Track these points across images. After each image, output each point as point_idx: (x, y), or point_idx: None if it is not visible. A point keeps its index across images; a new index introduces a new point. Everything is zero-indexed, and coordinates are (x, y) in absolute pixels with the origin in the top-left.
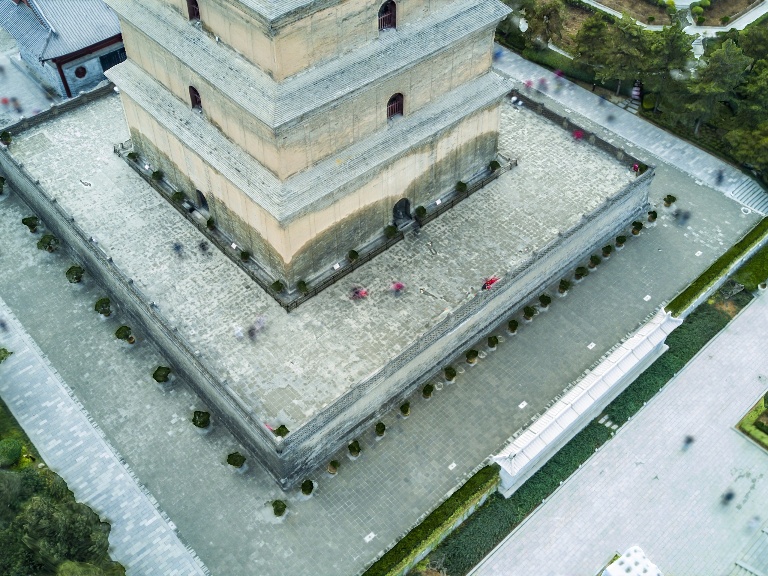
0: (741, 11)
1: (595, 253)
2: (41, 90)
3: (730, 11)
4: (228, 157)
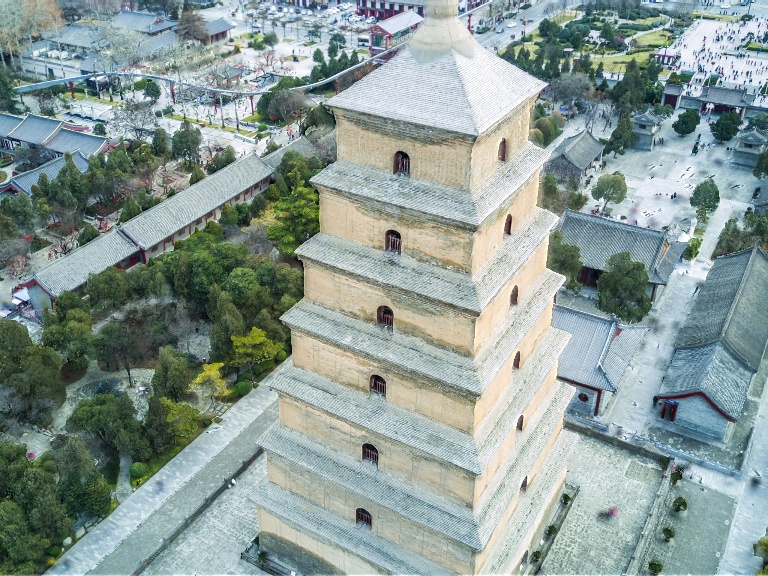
0: None
1: None
2: None
3: None
4: None
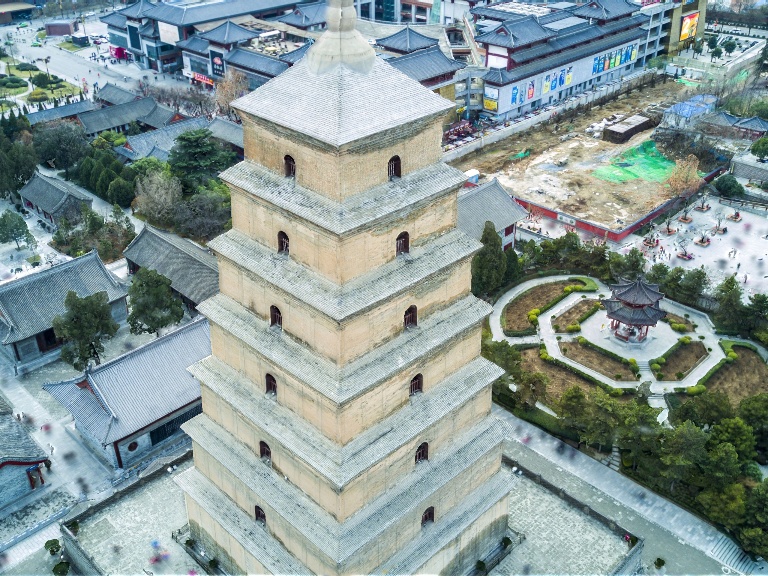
0: (692, 366)
1: None
2: (94, 460)
3: (683, 366)
4: (290, 570)
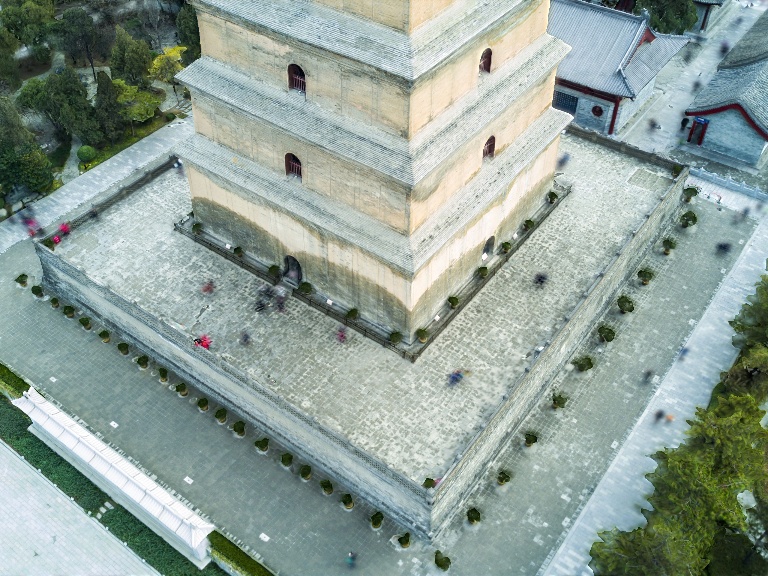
0: None
1: (330, 479)
2: None
3: None
4: None
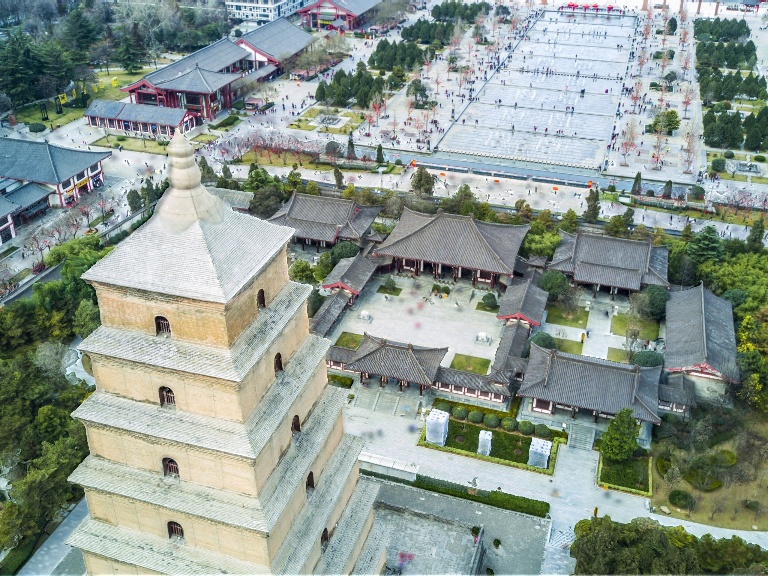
0: None
1: None
2: None
3: None
4: (364, 569)
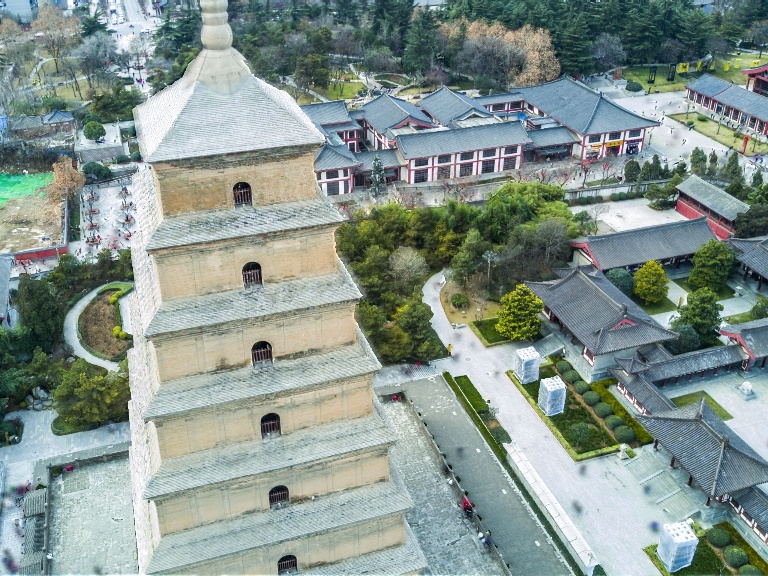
0: None
1: None
2: None
3: None
4: (348, 574)
